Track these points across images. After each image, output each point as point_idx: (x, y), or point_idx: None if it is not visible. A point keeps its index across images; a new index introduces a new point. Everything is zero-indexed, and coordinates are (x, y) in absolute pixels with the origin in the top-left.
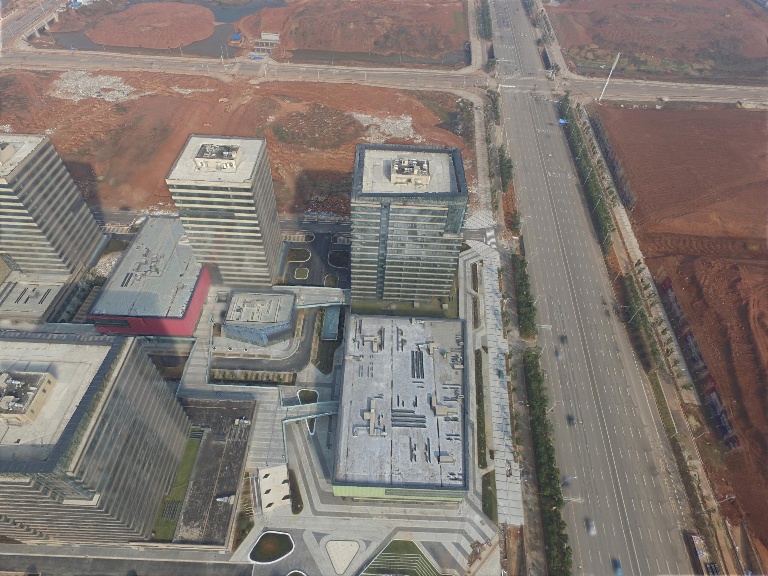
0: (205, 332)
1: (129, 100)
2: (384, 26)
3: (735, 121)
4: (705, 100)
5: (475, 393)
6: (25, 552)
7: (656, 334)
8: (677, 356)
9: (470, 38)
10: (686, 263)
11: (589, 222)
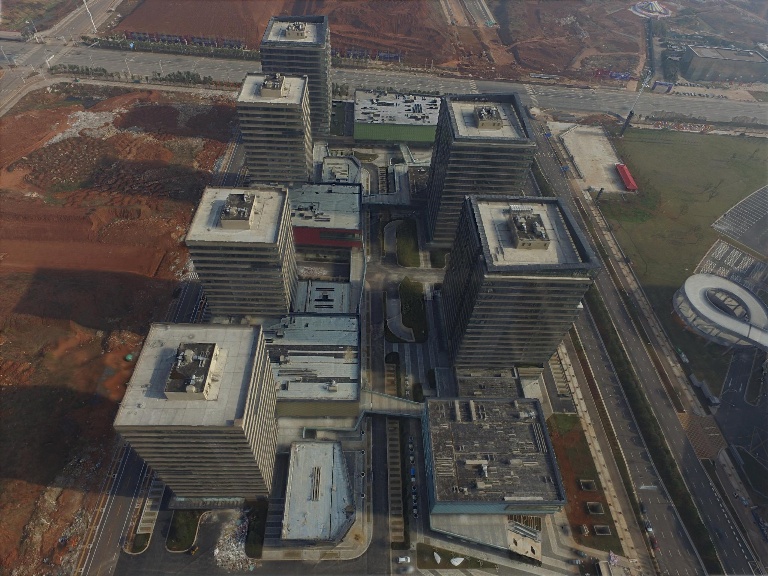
0: None
1: None
2: None
3: None
4: None
5: None
6: None
7: None
8: None
9: None
10: None
11: (253, 62)
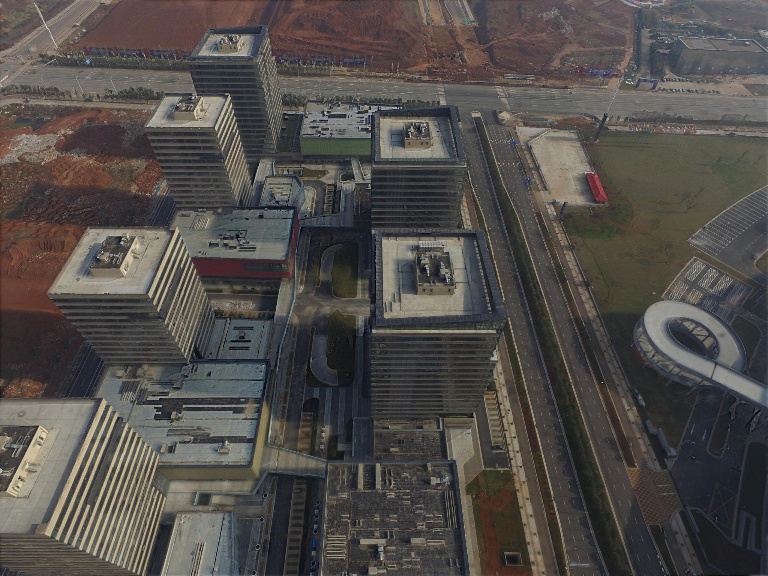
0: None
1: None
2: None
3: (141, 1)
4: (89, 13)
5: None
6: None
7: None
8: None
9: None
10: None
11: None
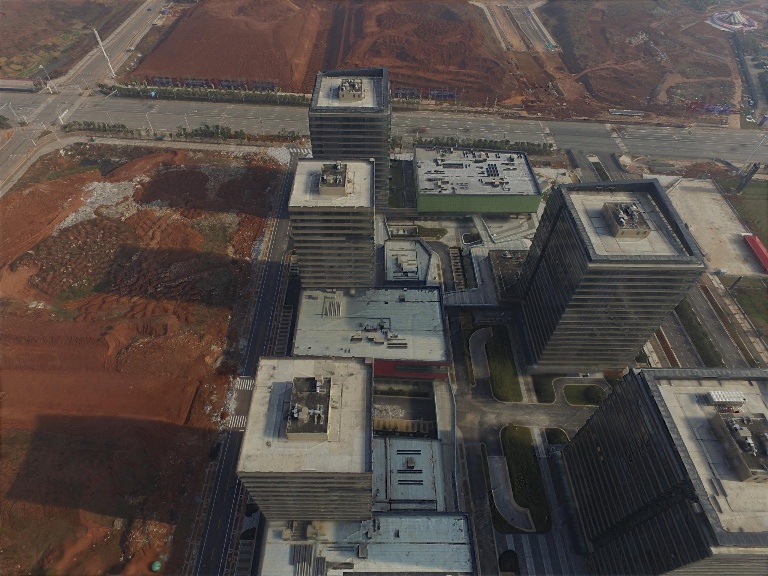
0: None
1: None
2: None
3: (200, 24)
4: (142, 35)
5: None
6: (627, 371)
7: None
8: None
9: None
10: None
11: (288, 108)
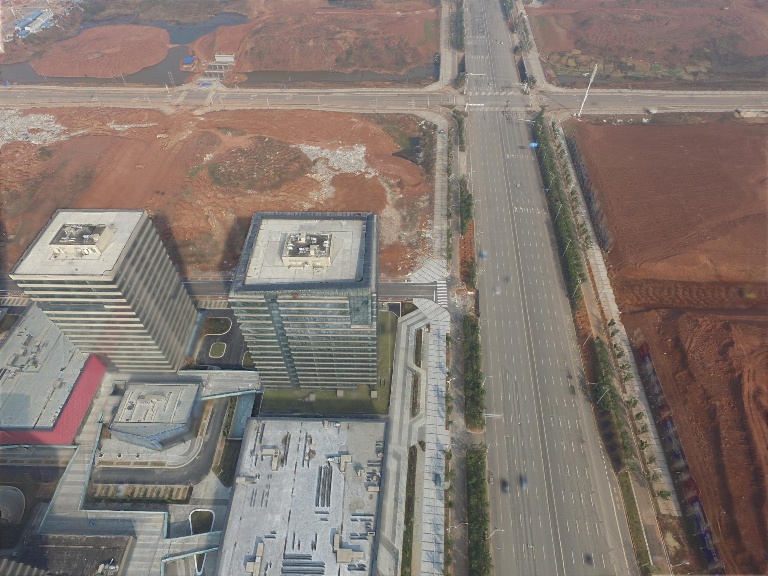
0: (90, 436)
1: (57, 142)
2: (346, 41)
3: (730, 138)
4: (699, 110)
5: (404, 508)
6: None
7: (630, 417)
8: (654, 447)
9: (440, 49)
10: (669, 320)
11: (558, 269)
